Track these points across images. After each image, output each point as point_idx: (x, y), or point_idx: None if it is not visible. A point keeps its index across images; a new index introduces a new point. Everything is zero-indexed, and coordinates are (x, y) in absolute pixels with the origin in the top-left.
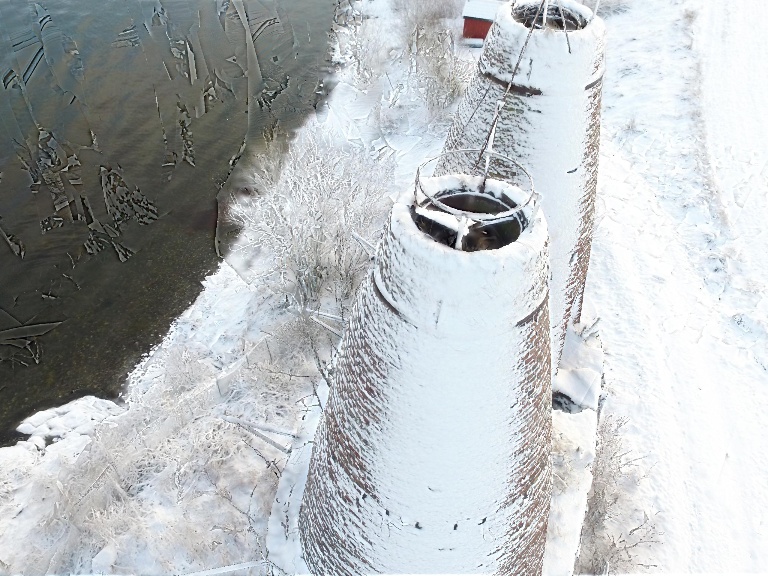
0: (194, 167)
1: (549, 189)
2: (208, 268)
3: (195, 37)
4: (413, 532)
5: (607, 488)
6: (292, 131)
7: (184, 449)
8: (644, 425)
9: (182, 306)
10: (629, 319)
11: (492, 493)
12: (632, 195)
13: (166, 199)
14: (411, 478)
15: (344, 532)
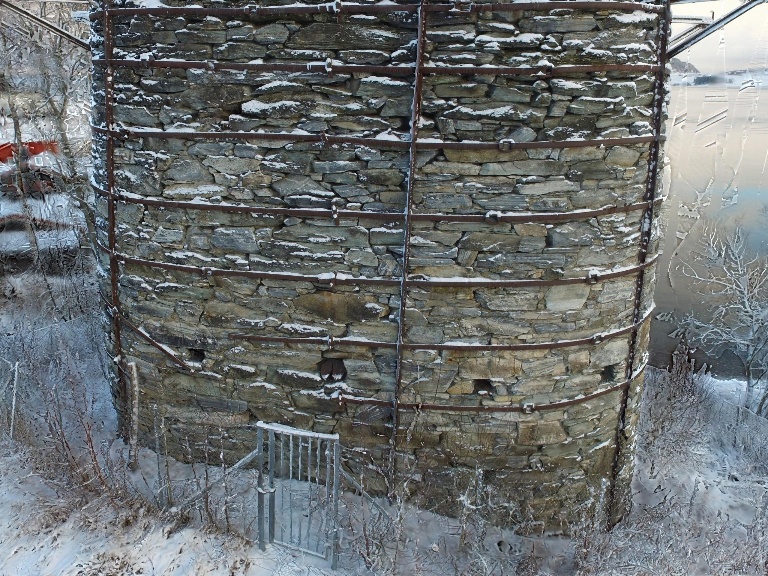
0: None
1: None
2: (720, 375)
3: None
4: None
5: None
6: None
7: None
8: None
9: None
10: None
11: None
12: None
13: None
14: None
15: None
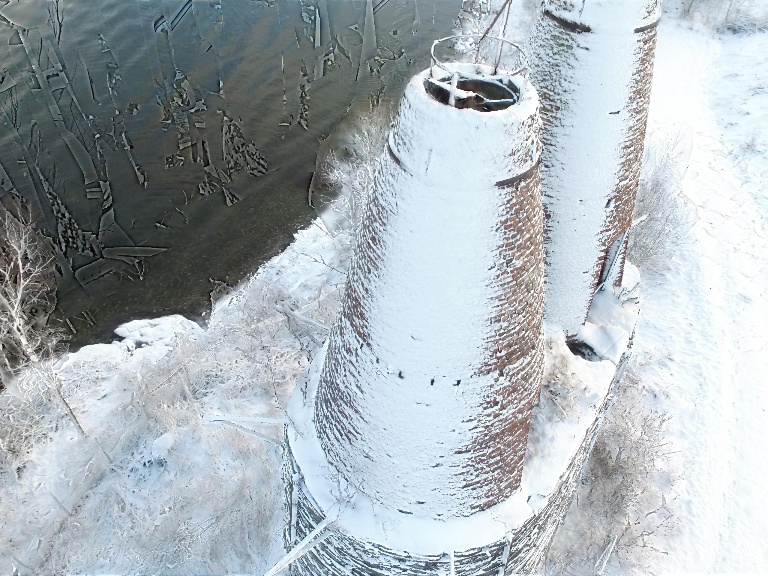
0: (307, 131)
1: (589, 127)
2: (302, 223)
3: (324, 3)
4: (396, 381)
5: (639, 481)
6: (397, 99)
7: (248, 369)
8: (693, 432)
9: (273, 252)
10: (702, 331)
11: (467, 354)
12: (736, 213)
13: (277, 157)
14: (398, 325)
15: (344, 383)
